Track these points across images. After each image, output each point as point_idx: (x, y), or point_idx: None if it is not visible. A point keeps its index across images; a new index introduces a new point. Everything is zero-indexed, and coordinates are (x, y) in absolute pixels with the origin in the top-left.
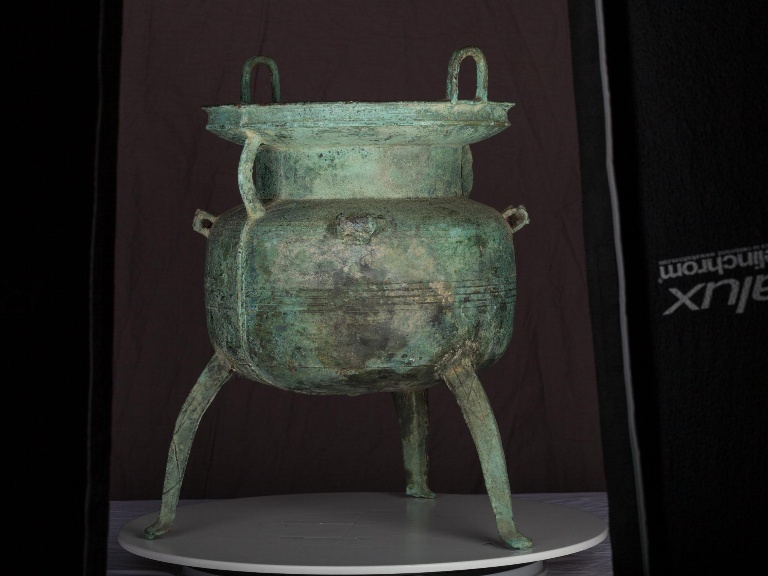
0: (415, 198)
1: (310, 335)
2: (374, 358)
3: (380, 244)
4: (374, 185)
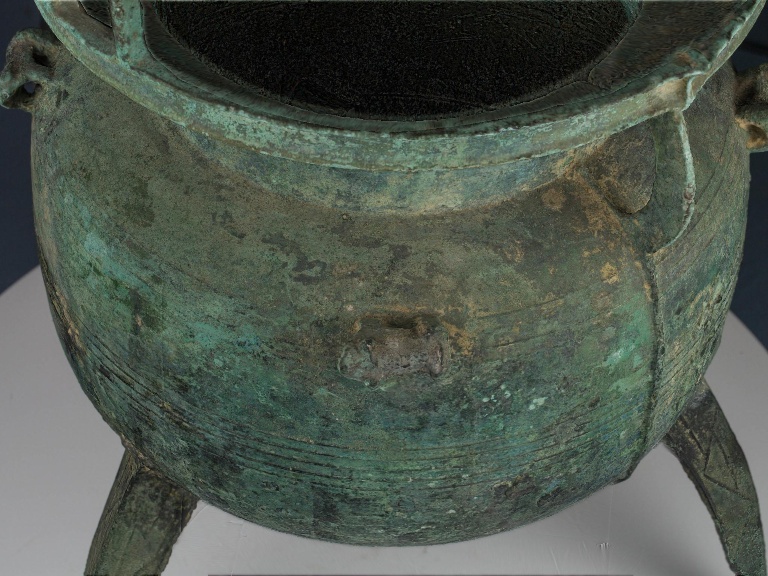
0: (169, 124)
1: None
2: None
3: None
4: None
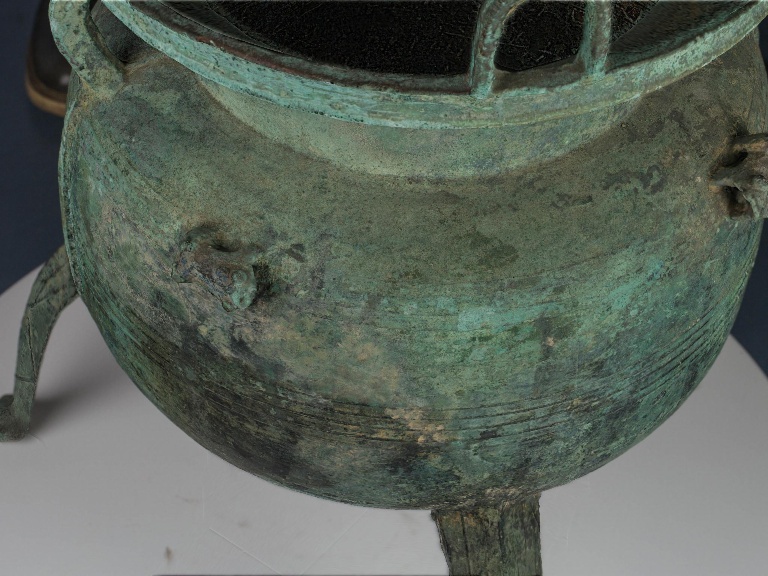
0: (431, 182)
1: (150, 386)
2: (267, 477)
3: (275, 317)
4: (332, 138)
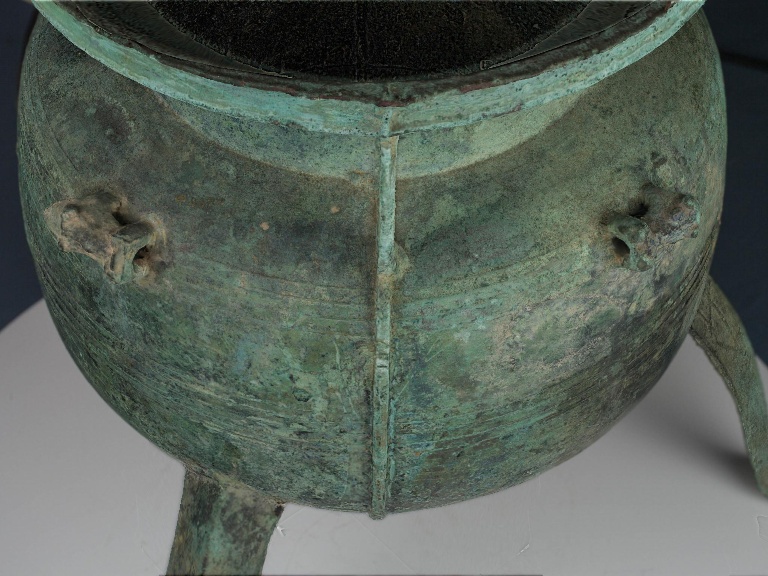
0: None
1: (555, 445)
2: None
3: None
4: None
